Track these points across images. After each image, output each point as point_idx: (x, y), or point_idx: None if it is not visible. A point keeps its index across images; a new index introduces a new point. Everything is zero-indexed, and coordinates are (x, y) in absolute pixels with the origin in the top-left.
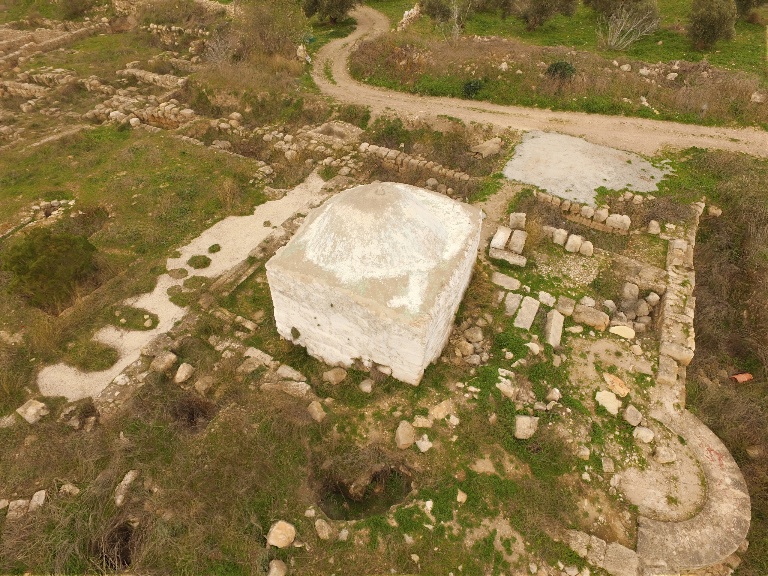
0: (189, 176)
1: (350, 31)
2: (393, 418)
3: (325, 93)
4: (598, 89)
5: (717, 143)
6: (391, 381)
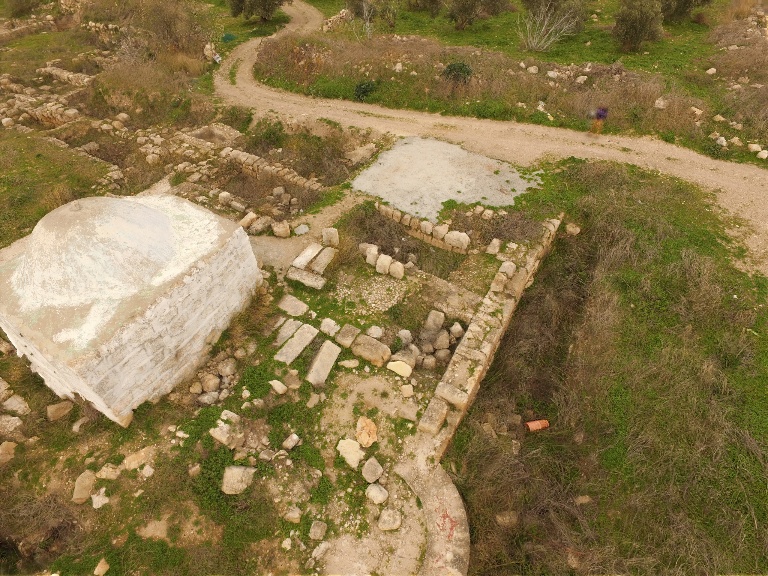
0: (31, 180)
1: (276, 30)
2: (82, 465)
3: (217, 94)
4: (494, 92)
5: (605, 153)
6: (101, 421)
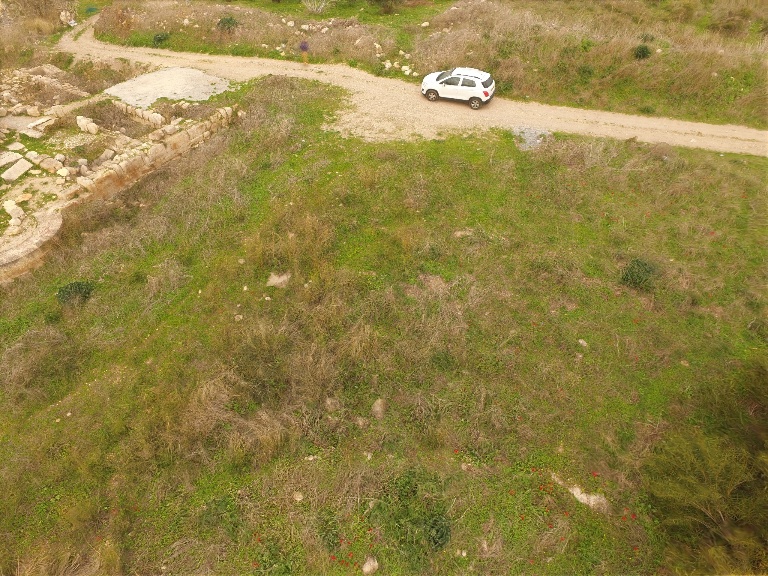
0: None
1: None
2: None
3: (57, 46)
4: (249, 38)
5: (304, 74)
6: None
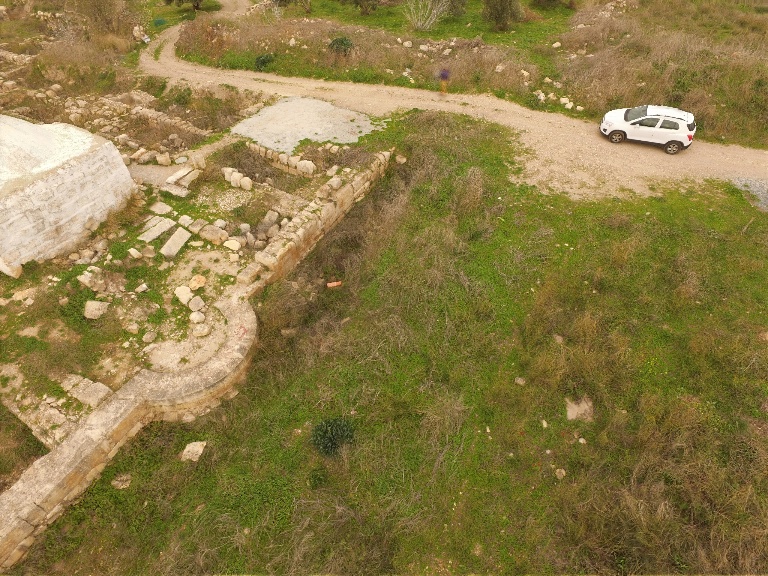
0: None
1: None
2: None
3: (140, 67)
4: (369, 62)
5: (447, 106)
6: None
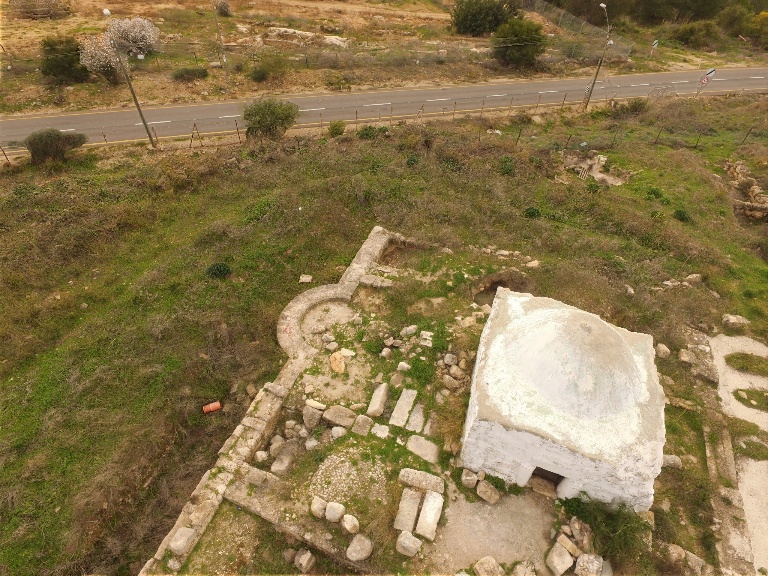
0: None
1: None
2: None
3: None
4: None
5: None
6: None
